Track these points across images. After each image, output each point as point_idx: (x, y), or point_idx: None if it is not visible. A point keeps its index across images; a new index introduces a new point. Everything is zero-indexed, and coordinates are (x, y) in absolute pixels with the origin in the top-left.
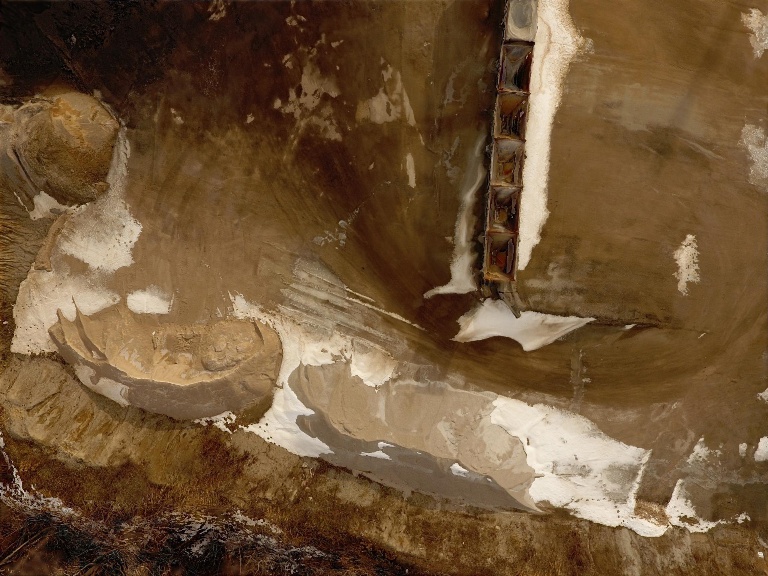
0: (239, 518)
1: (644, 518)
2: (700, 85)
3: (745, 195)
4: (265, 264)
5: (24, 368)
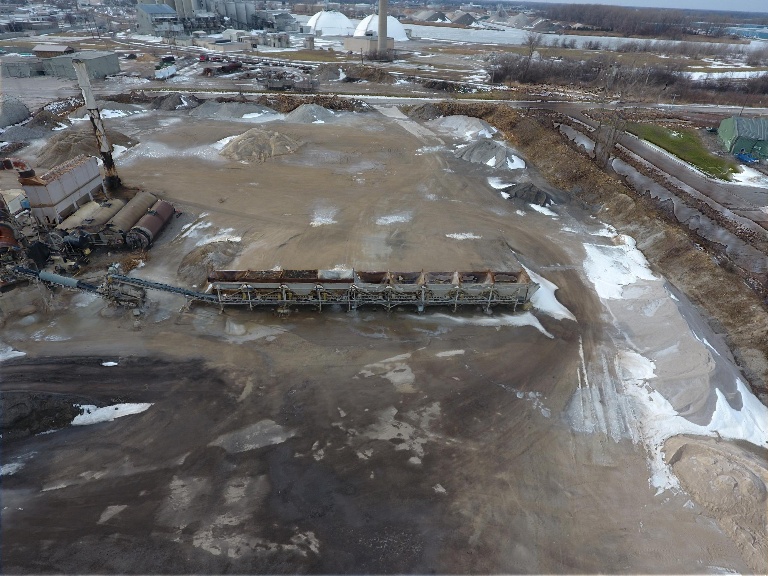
0: None
1: (624, 241)
2: (357, 235)
3: (416, 222)
4: (599, 459)
5: None
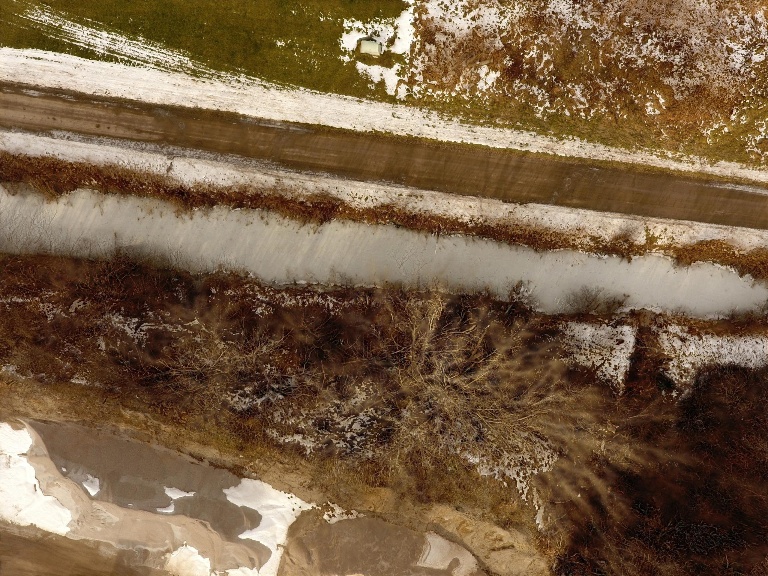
0: (310, 442)
1: None
2: None
3: None
4: None
5: (524, 571)
